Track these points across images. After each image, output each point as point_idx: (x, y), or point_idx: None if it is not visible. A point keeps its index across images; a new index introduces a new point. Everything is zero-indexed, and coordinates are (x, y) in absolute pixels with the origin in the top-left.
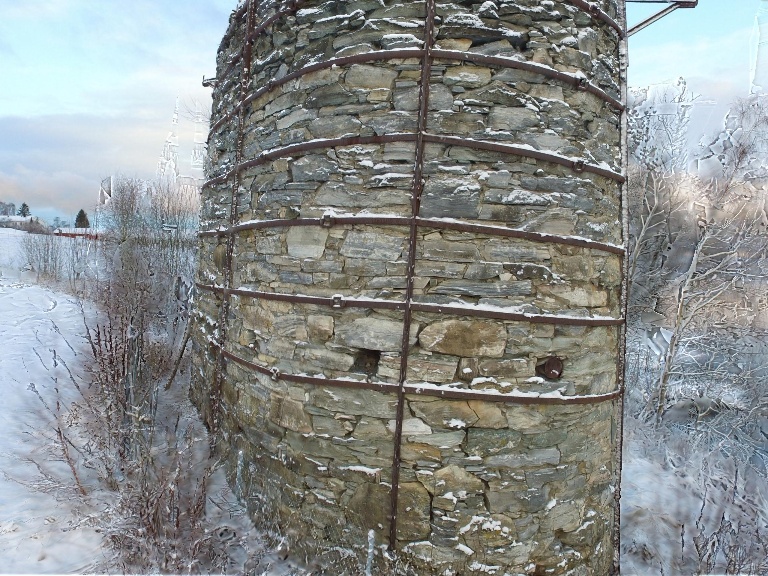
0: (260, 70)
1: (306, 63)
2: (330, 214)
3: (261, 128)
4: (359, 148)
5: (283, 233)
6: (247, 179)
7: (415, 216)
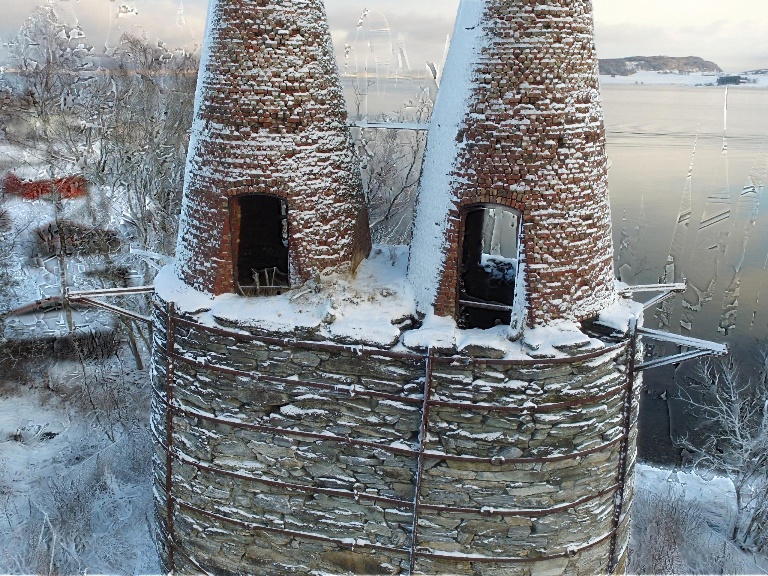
0: (465, 440)
1: (550, 454)
2: (574, 549)
3: (476, 488)
4: (591, 504)
5: (527, 567)
6: (444, 519)
7: (616, 528)
